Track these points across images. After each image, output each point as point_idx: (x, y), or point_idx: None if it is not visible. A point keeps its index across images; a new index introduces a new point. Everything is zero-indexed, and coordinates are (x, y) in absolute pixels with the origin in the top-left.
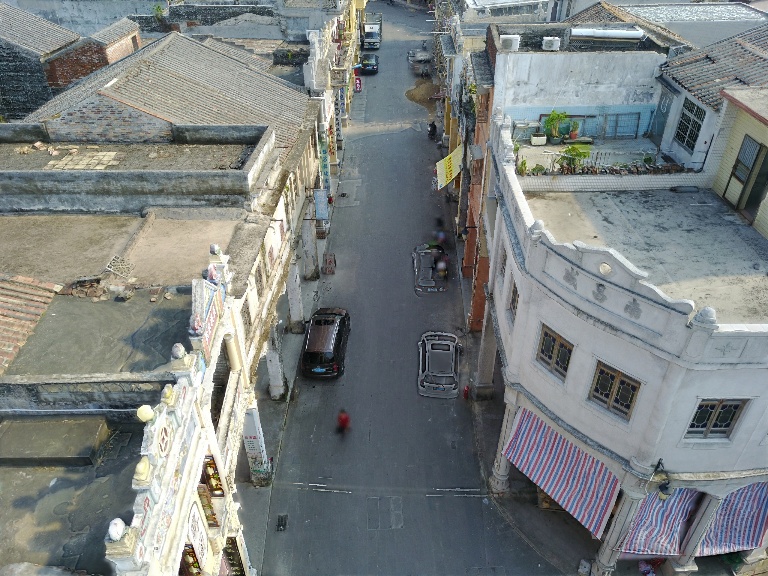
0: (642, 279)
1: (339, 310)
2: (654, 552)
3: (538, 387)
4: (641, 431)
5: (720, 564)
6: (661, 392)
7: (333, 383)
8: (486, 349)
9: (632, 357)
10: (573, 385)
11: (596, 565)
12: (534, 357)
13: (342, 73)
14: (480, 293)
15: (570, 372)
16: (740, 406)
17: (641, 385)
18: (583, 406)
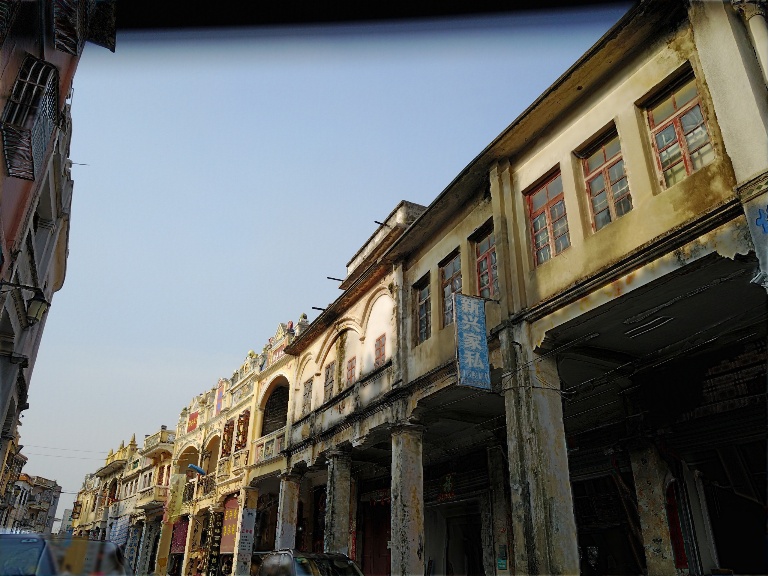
0: None
1: None
2: None
3: None
4: None
5: None
6: None
7: None
8: None
9: None
10: None
11: None
12: None
13: None
14: None
15: None
16: None
17: None
18: None
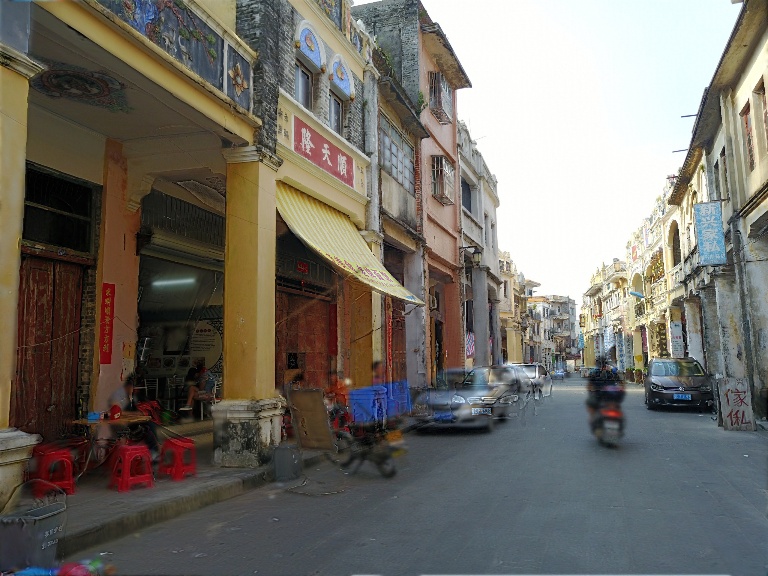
0: None
1: (667, 385)
2: None
3: None
4: None
5: None
6: None
7: None
8: None
9: None
10: None
11: None
12: None
13: None
14: None
15: None
16: None
17: None
18: None
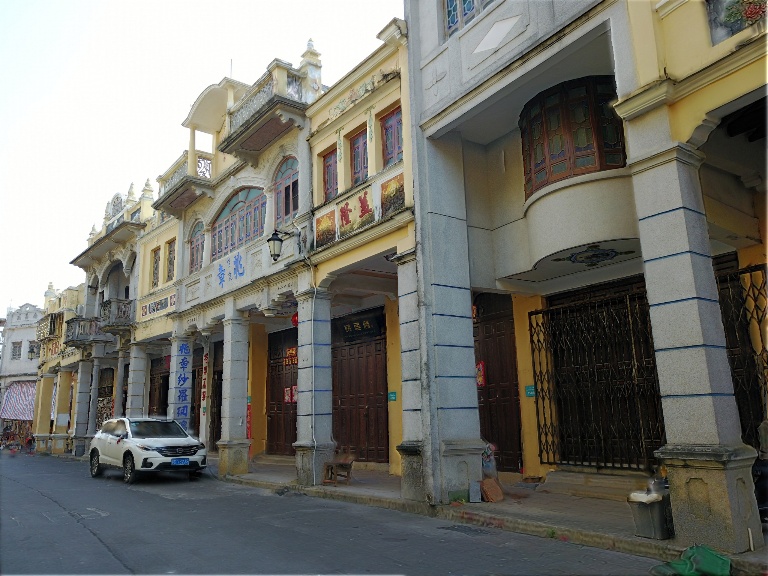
0: None
1: None
2: None
3: (12, 369)
4: None
5: None
6: None
7: None
8: None
9: None
10: (23, 356)
11: None
12: (11, 359)
13: None
14: None
15: (22, 352)
16: None
17: None
18: (26, 361)
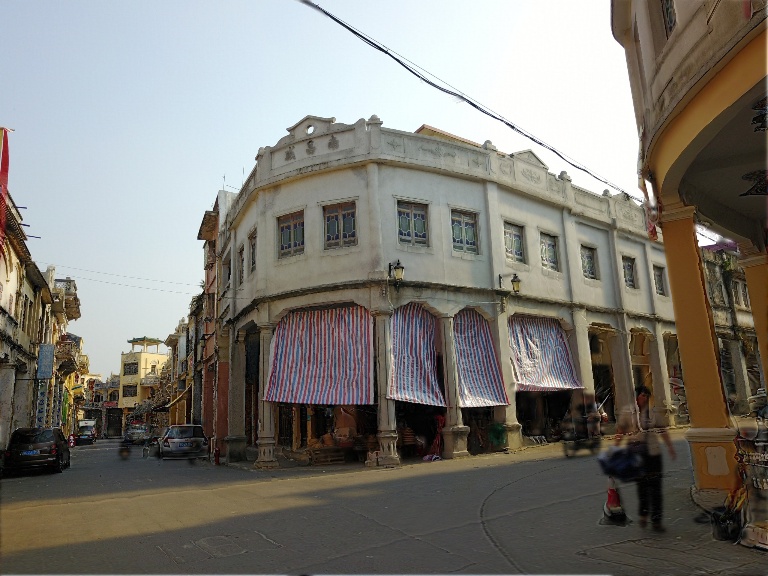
0: (333, 122)
1: None
2: (424, 403)
3: (285, 278)
4: (368, 242)
5: (492, 451)
6: (369, 196)
7: (47, 475)
8: (234, 387)
9: (344, 185)
10: (311, 244)
11: (380, 446)
12: (277, 257)
13: (68, 346)
14: (222, 405)
15: (306, 235)
16: (425, 216)
17: (356, 202)
18: (322, 256)
